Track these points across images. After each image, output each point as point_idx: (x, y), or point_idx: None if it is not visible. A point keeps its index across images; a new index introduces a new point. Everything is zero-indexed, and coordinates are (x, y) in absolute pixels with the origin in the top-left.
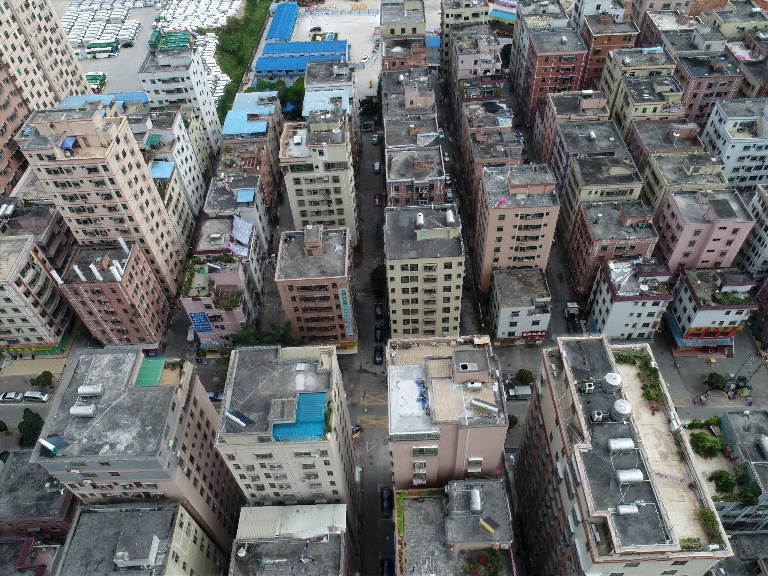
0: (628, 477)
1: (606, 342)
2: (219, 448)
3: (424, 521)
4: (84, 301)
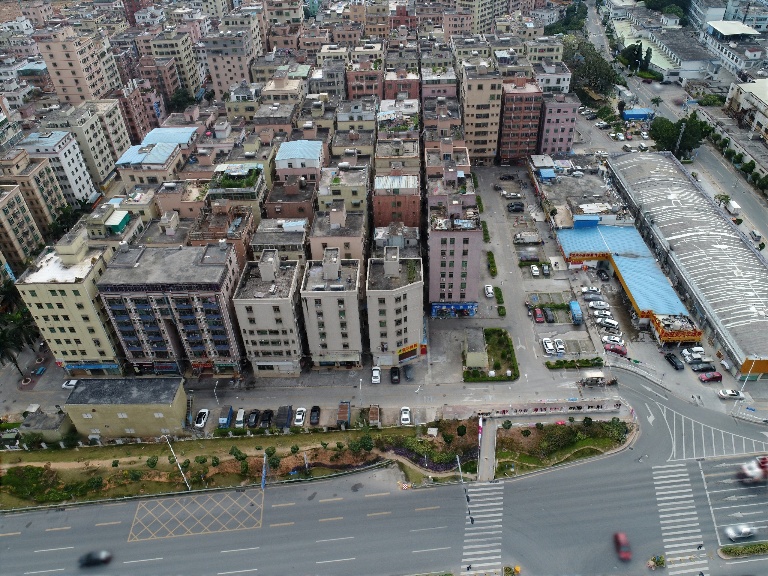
0: None
1: None
2: None
3: None
4: None
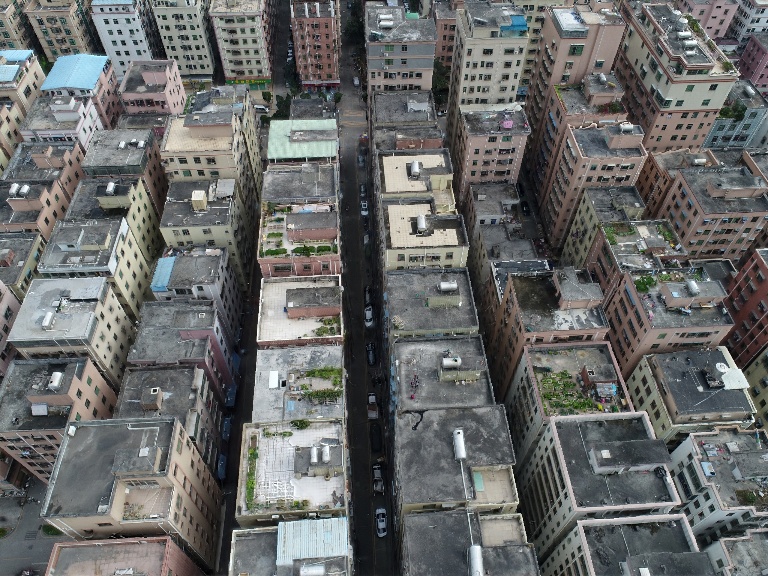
0: (690, 42)
1: (669, 4)
2: (467, 42)
3: (571, 97)
4: (303, 35)
